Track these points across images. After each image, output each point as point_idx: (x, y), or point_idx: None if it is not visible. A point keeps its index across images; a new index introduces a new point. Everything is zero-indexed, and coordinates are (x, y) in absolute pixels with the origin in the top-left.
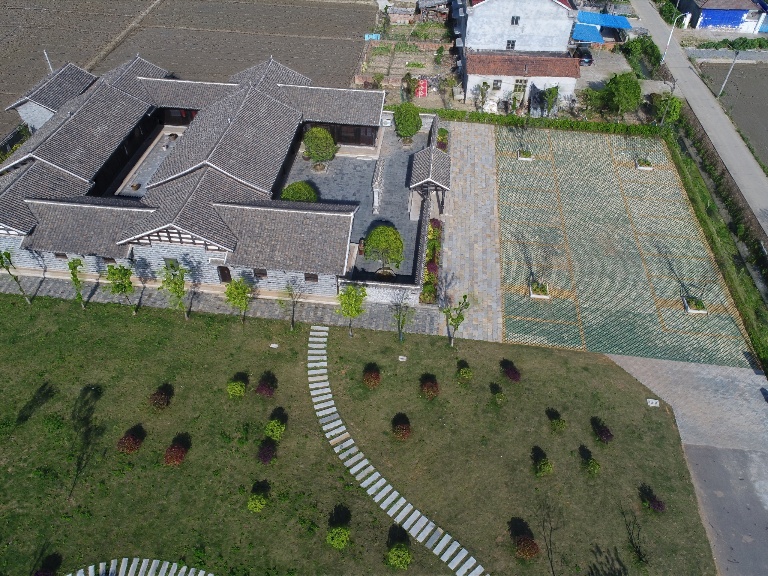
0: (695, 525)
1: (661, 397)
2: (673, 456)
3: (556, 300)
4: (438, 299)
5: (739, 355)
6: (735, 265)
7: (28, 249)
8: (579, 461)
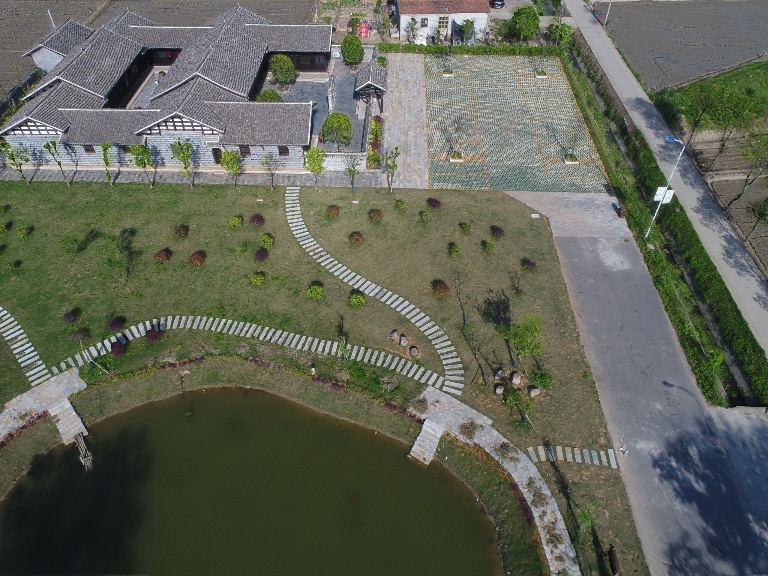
0: (557, 276)
1: (541, 212)
2: (546, 243)
3: (469, 162)
4: (381, 165)
5: (599, 186)
6: (606, 137)
7: (65, 143)
8: (481, 248)
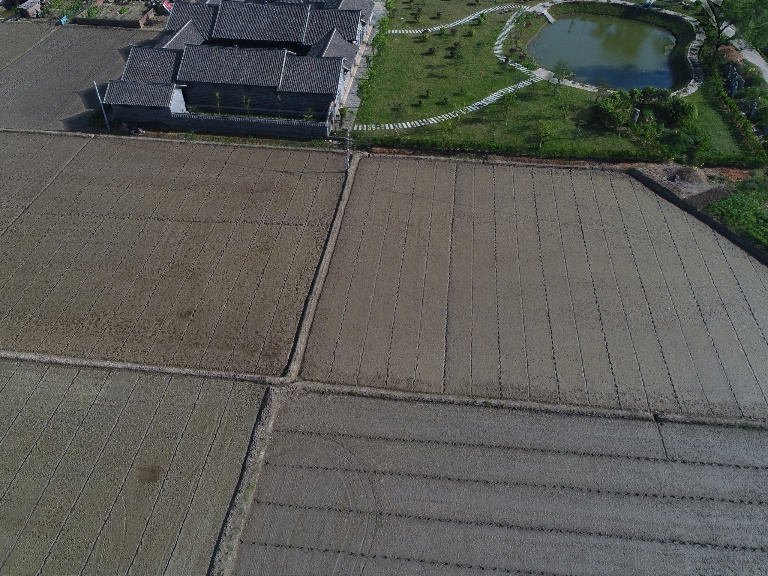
0: None
1: None
2: None
3: None
4: None
5: None
6: None
7: None
8: None
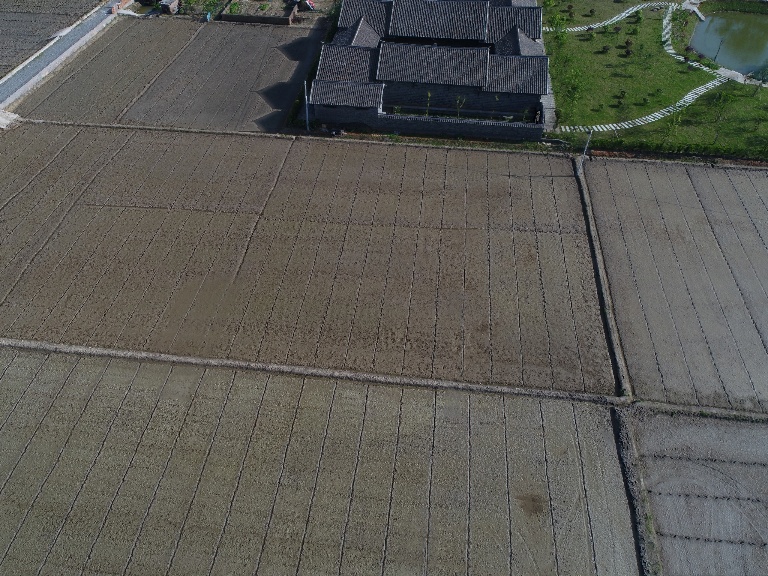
0: None
1: None
2: None
3: None
4: None
5: None
6: None
7: None
8: None
